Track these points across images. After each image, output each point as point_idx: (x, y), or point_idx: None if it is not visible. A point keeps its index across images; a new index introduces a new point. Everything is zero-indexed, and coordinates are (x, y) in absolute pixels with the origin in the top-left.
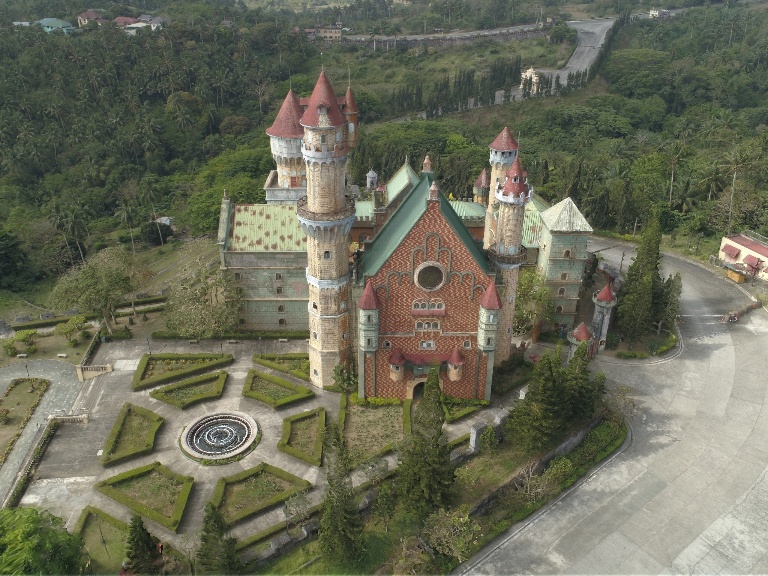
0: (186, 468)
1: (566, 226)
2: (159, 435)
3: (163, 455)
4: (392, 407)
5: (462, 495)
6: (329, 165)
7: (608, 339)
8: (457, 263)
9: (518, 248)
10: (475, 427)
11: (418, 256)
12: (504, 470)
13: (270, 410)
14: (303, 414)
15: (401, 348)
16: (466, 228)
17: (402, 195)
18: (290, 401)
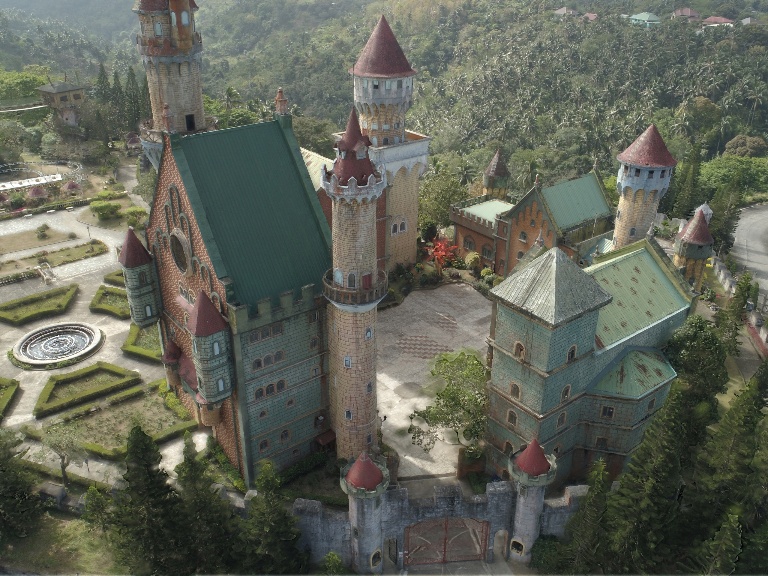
0: (0, 350)
1: (516, 294)
2: (45, 318)
3: (15, 332)
4: (179, 418)
5: (36, 548)
6: (151, 66)
7: (535, 548)
8: (197, 245)
9: (351, 278)
10: (116, 482)
11: (171, 215)
12: (107, 567)
13: (121, 351)
14: (117, 368)
15: (182, 344)
16: (319, 220)
17: (526, 203)
18: (136, 352)
